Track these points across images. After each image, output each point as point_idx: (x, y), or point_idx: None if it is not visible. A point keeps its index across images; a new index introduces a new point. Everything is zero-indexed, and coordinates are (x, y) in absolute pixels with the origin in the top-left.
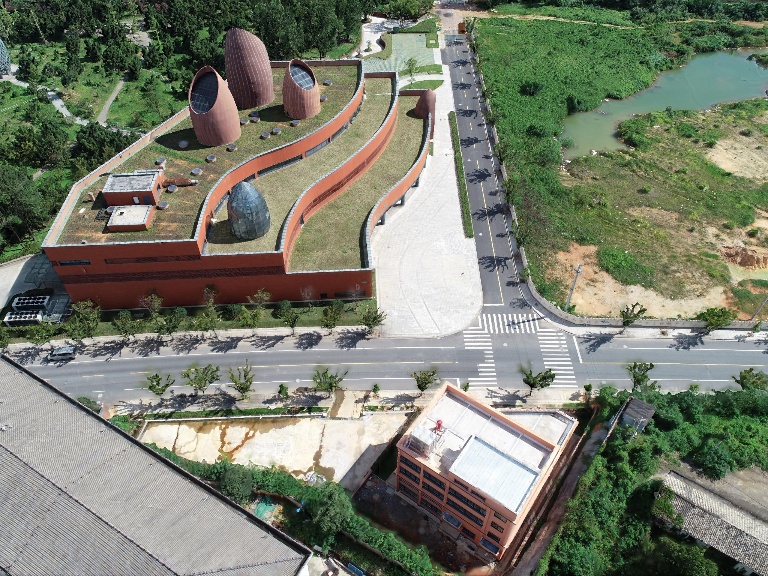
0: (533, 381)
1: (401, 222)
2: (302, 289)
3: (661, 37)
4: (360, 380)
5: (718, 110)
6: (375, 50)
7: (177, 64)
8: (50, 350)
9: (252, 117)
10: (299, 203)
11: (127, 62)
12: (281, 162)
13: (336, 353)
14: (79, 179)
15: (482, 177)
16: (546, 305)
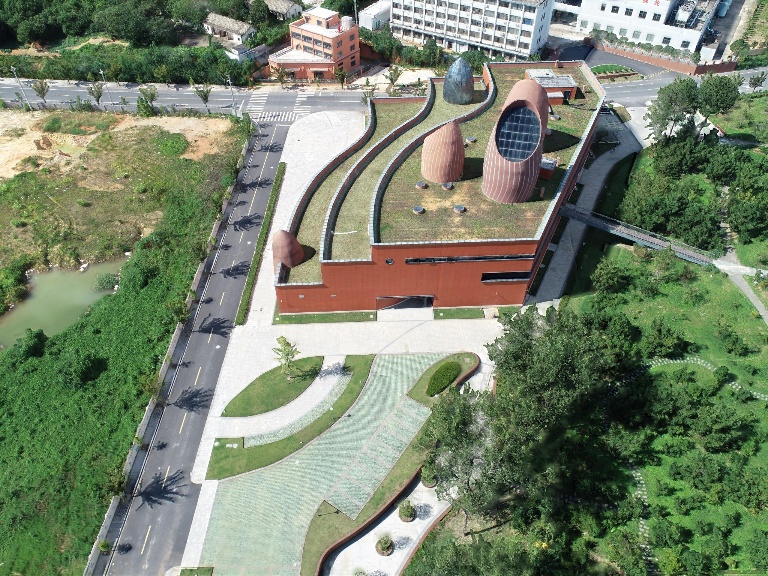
0: None
1: None
2: None
3: None
4: None
5: None
6: None
7: None
8: None
9: None
10: None
11: None
12: None
13: None
14: None
15: (245, 221)
16: None
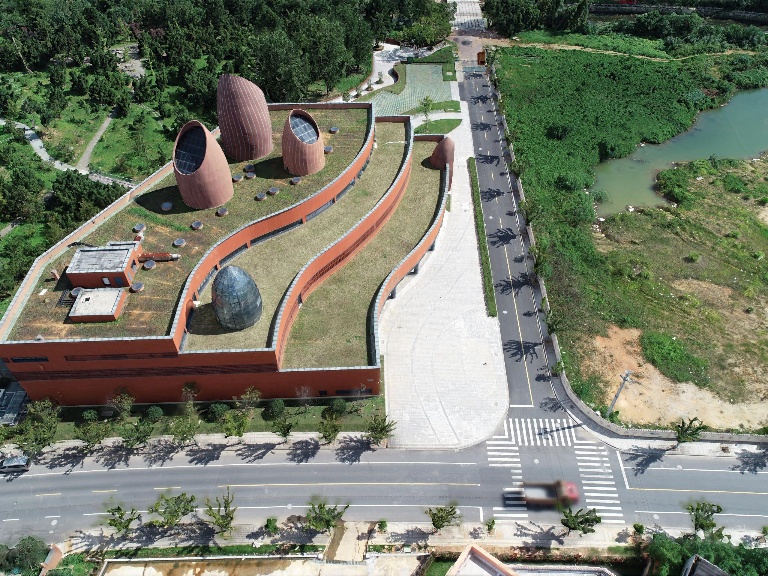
0: (574, 525)
1: (414, 295)
2: (298, 388)
3: (699, 72)
4: (364, 507)
5: (767, 159)
6: (387, 82)
7: (171, 98)
8: (1, 458)
9: (247, 172)
10: (296, 283)
11: (116, 96)
12: (278, 229)
13: (336, 469)
14: (51, 239)
15: (506, 239)
16: (584, 409)
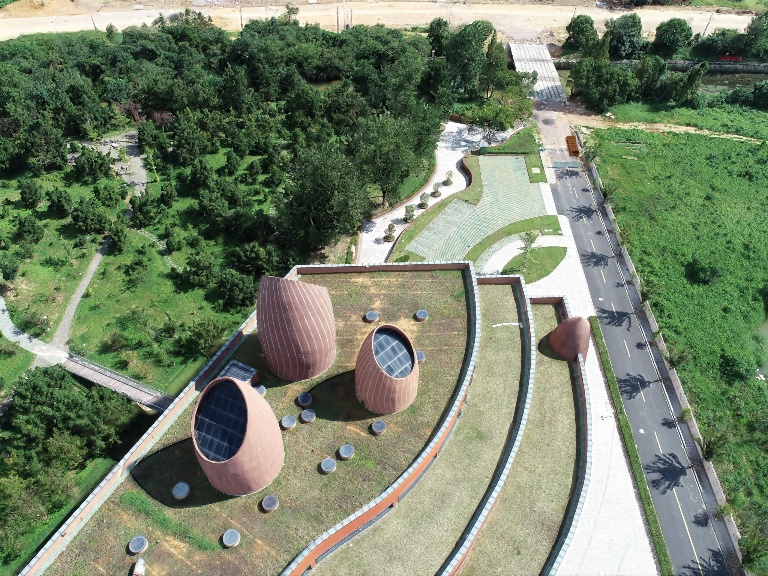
0: None
1: None
2: None
3: None
4: None
5: None
6: (457, 182)
7: (181, 217)
8: None
9: (302, 410)
10: None
11: (108, 222)
12: (357, 528)
13: None
14: (5, 503)
15: (673, 476)
16: None
